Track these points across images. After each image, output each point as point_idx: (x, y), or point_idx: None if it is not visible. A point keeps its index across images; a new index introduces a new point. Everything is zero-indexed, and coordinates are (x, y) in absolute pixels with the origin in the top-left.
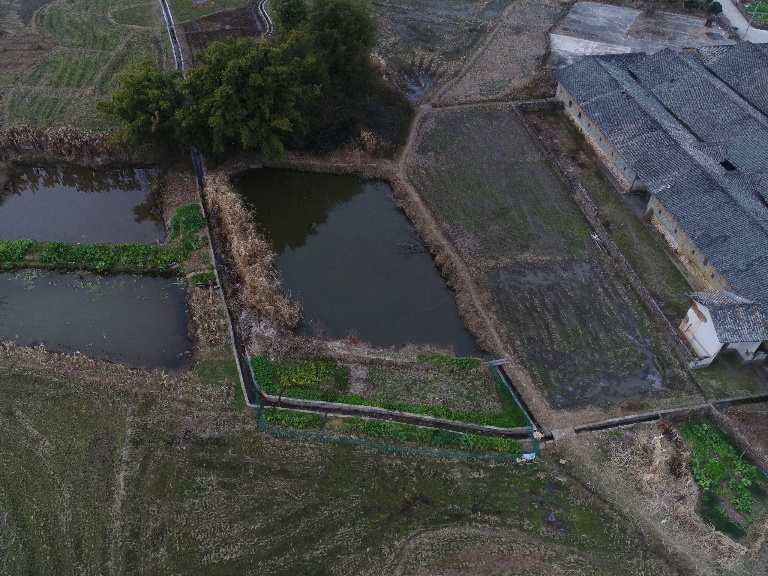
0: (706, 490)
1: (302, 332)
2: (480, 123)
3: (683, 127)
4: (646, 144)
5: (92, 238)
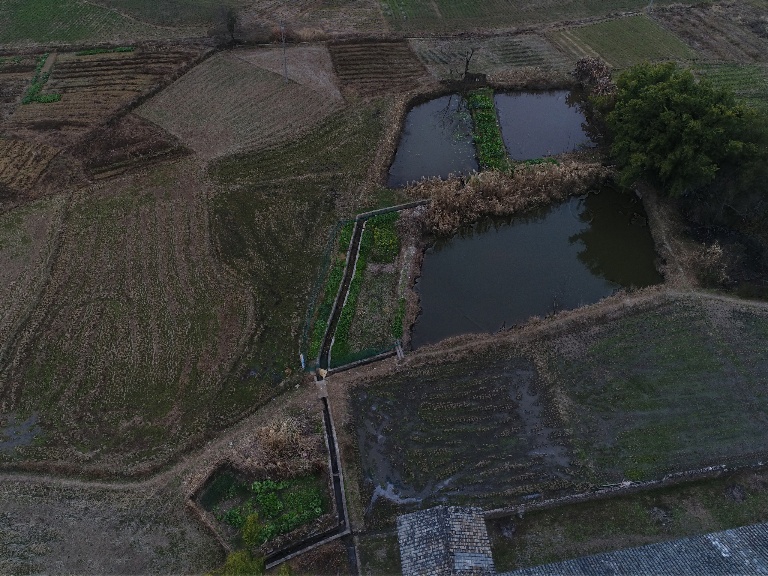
0: None
1: None
2: None
3: None
4: None
5: (511, 133)
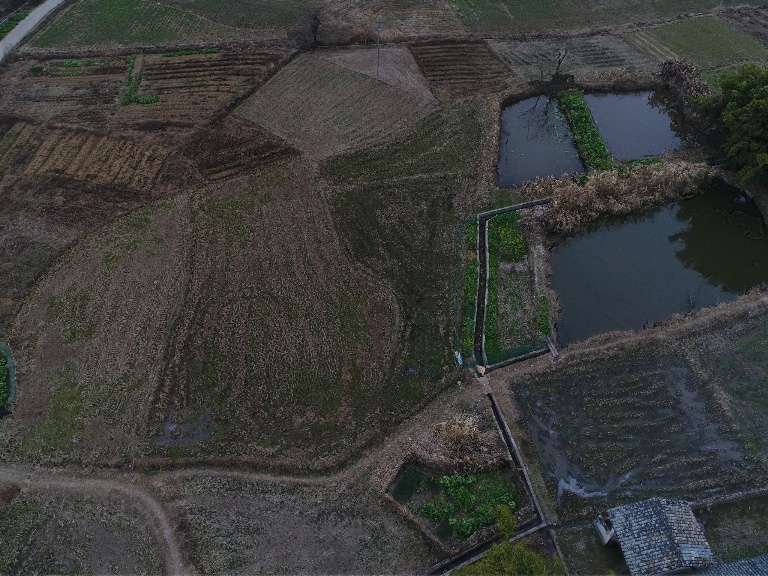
0: None
1: (552, 236)
2: None
3: None
4: None
5: (608, 133)
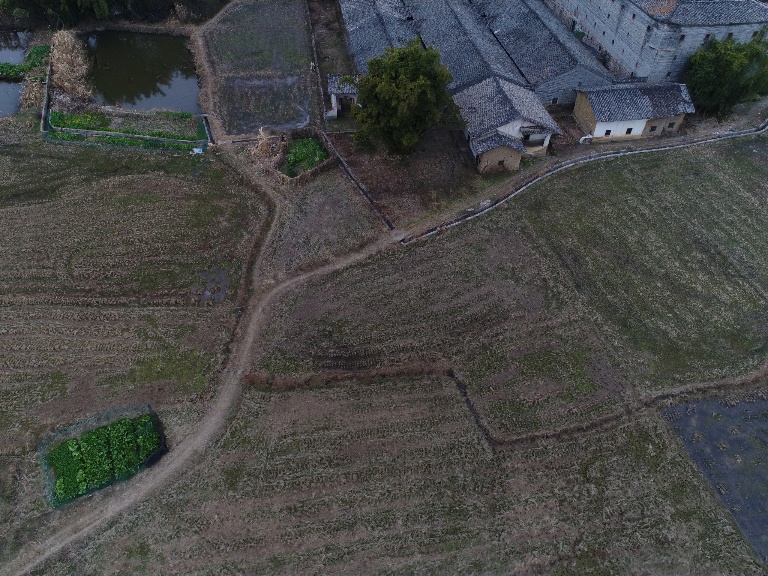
0: (292, 163)
1: None
2: (275, 7)
3: (400, 1)
4: (359, 6)
5: None
